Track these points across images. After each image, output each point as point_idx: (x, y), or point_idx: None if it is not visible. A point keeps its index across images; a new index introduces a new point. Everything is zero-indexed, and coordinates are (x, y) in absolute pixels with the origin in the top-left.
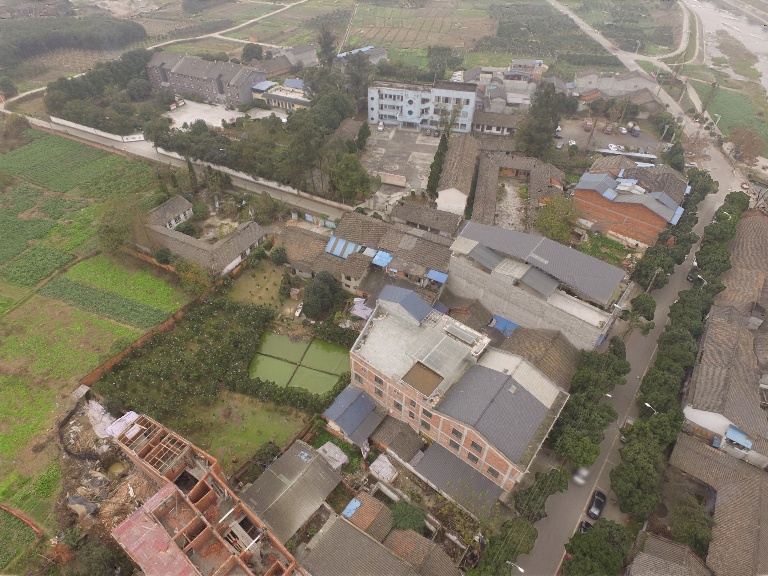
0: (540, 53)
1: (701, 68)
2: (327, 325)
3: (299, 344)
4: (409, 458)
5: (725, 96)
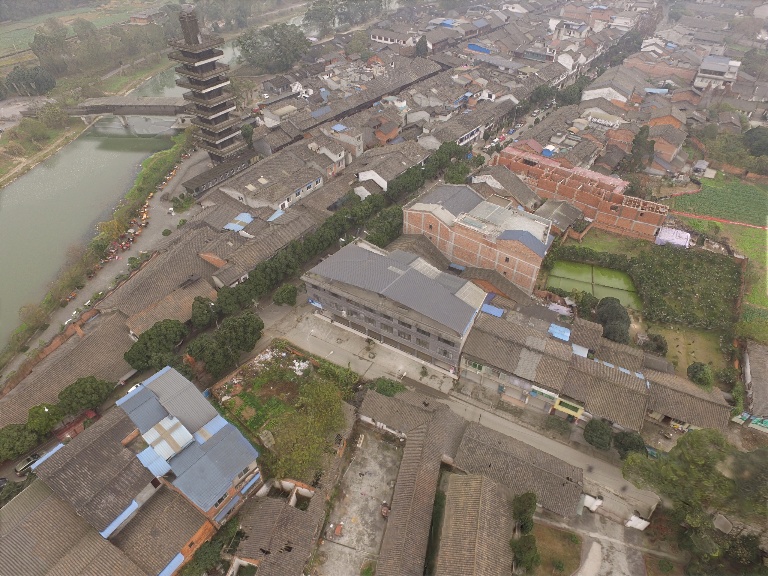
0: None
1: None
2: (586, 299)
3: None
4: None
5: None
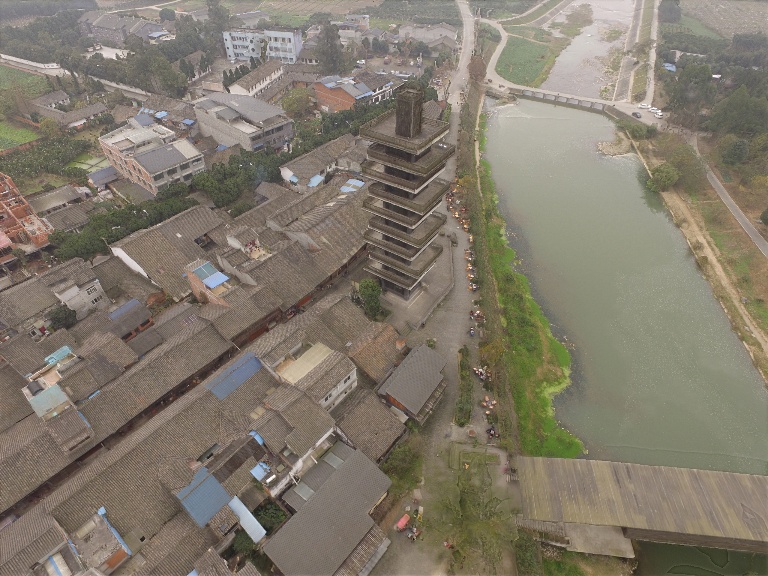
0: (401, 17)
1: (531, 28)
2: None
3: (100, 158)
4: None
5: (528, 46)
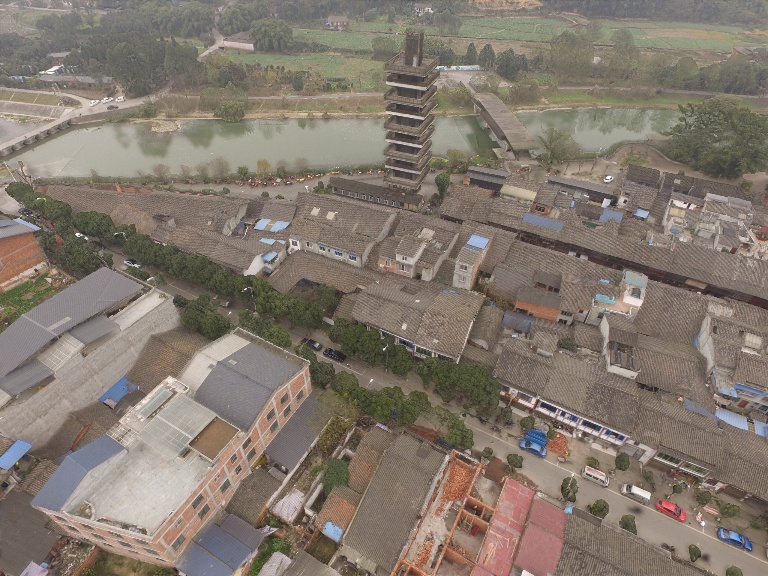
0: None
1: None
2: None
3: None
4: (277, 481)
5: None
